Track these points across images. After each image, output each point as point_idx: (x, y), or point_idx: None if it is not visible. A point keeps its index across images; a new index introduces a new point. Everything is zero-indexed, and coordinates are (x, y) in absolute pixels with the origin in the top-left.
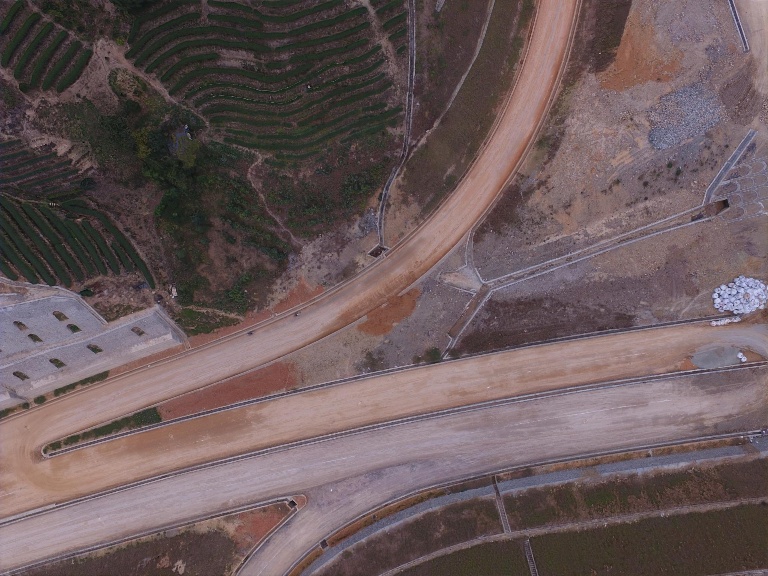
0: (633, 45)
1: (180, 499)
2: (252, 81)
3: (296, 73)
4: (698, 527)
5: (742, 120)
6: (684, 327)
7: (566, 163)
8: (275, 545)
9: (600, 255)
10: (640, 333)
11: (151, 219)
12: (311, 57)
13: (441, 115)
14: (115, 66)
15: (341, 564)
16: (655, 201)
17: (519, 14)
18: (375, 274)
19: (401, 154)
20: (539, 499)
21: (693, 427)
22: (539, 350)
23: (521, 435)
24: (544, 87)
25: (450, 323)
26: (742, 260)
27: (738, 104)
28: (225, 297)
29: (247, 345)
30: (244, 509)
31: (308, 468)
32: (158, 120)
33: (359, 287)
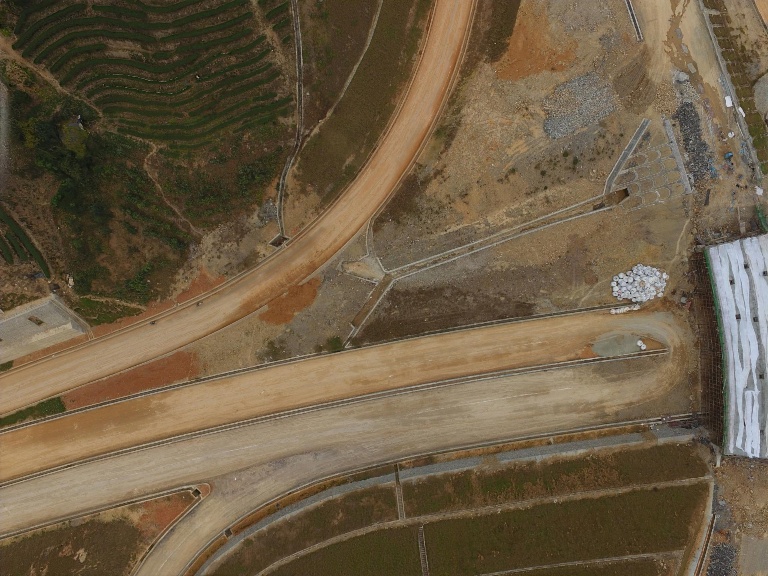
0: (526, 35)
1: (85, 488)
2: (141, 71)
3: (183, 63)
4: (589, 513)
5: (635, 109)
6: (584, 315)
7: (462, 152)
8: (180, 534)
9: (501, 244)
10: (540, 321)
11: (48, 209)
12: (196, 47)
13: (334, 105)
14: (3, 57)
15: (242, 552)
16: (555, 190)
17: (416, 5)
18: (276, 264)
19: (295, 144)
20: (437, 486)
21: (594, 415)
22: (440, 339)
23: (423, 423)
24: (443, 77)
25: (352, 312)
26: (641, 248)
27: (631, 93)
28: (125, 287)
29: (150, 335)
30: (149, 498)
31: (212, 457)
32: (50, 111)
33: (261, 277)
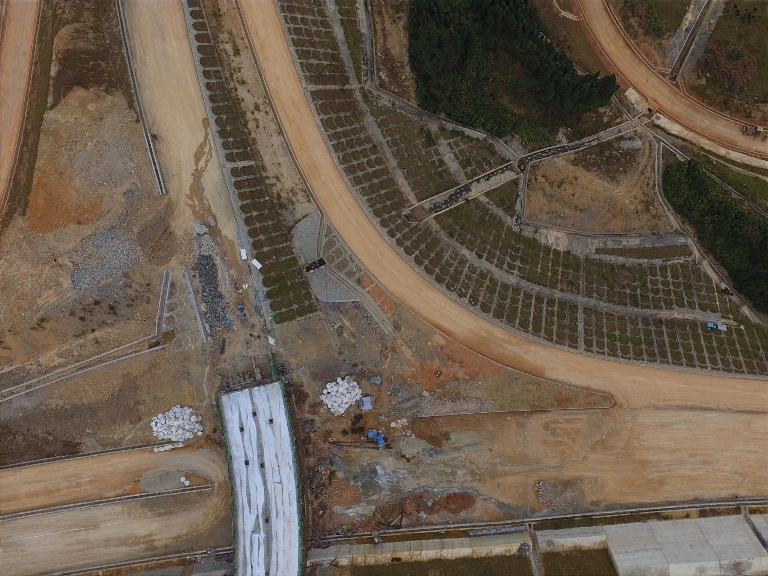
0: (50, 191)
1: None
2: None
3: None
4: None
5: (156, 261)
6: (131, 453)
7: None
8: None
9: (56, 383)
10: (89, 459)
11: None
12: None
13: None
14: None
15: None
16: (104, 332)
17: None
18: None
19: None
20: None
21: (144, 548)
22: None
23: None
24: None
25: None
26: (184, 388)
27: (152, 246)
28: None
29: None
30: None
31: None
32: None
33: None
